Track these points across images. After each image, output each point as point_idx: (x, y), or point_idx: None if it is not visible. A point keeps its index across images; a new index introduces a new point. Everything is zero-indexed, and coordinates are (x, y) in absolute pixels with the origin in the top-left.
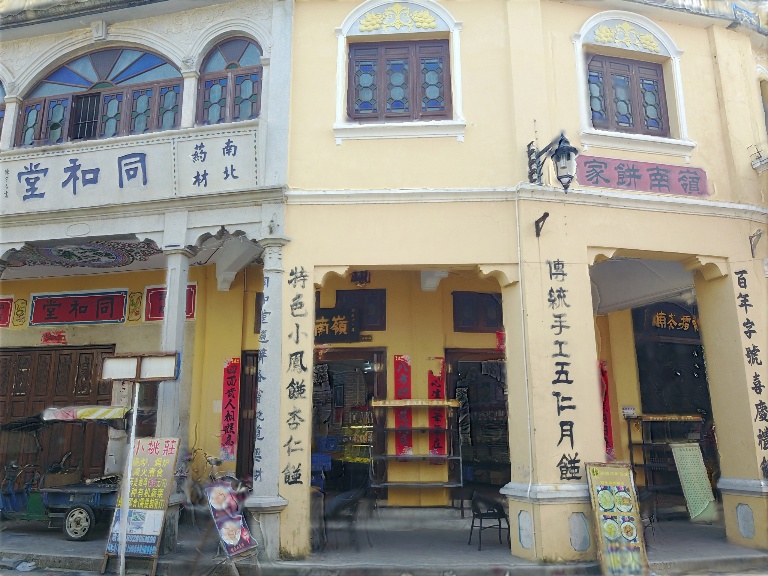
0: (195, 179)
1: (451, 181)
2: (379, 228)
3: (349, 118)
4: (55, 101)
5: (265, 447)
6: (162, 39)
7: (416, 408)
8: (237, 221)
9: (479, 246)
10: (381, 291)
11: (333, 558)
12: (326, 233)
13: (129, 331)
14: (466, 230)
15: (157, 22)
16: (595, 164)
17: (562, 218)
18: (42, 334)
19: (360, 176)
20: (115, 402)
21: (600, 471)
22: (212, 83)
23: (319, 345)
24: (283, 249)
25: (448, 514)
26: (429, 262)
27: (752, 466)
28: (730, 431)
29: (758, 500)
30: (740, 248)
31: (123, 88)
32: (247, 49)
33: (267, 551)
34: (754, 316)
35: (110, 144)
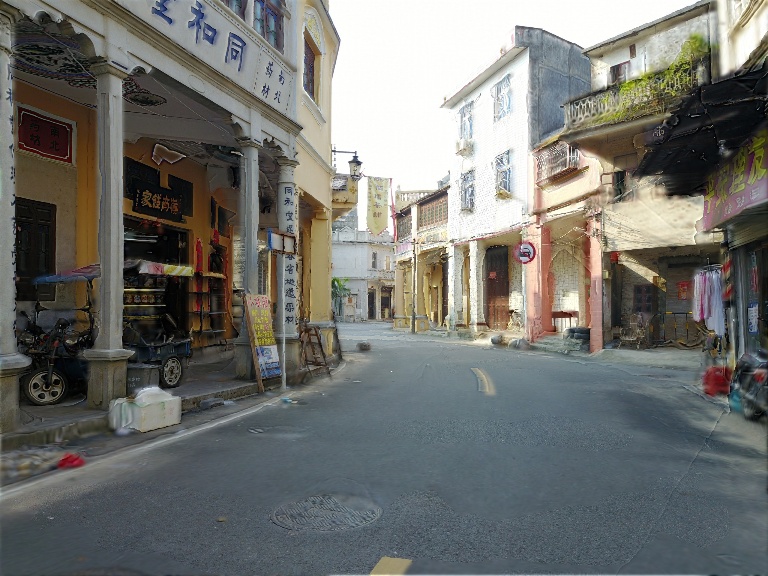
0: (263, 88)
1: None
2: None
3: None
4: None
5: None
6: None
7: (207, 278)
8: None
9: None
10: (191, 184)
11: None
12: None
13: None
14: None
15: None
16: None
17: None
18: None
19: None
20: None
21: None
22: None
23: (158, 219)
24: None
25: (219, 349)
26: None
27: None
28: None
29: None
30: None
31: None
32: None
33: None
34: None
35: (227, 14)
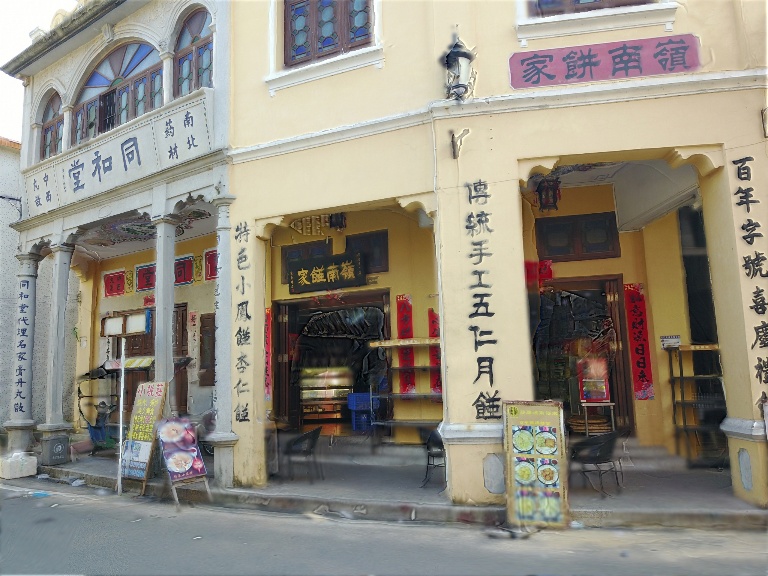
0: (170, 153)
1: (374, 113)
2: (307, 174)
3: (283, 67)
4: (90, 103)
5: (219, 389)
6: (146, 28)
7: (416, 347)
8: (198, 187)
9: (397, 178)
10: (384, 232)
11: (274, 488)
12: (264, 186)
13: (195, 290)
14: (385, 163)
15: (143, 13)
16: (535, 60)
17: (486, 132)
18: (143, 298)
19: (292, 124)
20: (190, 352)
21: (520, 410)
22: (183, 60)
23: (334, 290)
24: (230, 207)
25: None
26: (350, 202)
27: (748, 403)
28: (731, 361)
29: (751, 444)
30: (745, 128)
31: (129, 80)
32: (207, 19)
33: (222, 479)
34: (761, 215)
35: (115, 134)
